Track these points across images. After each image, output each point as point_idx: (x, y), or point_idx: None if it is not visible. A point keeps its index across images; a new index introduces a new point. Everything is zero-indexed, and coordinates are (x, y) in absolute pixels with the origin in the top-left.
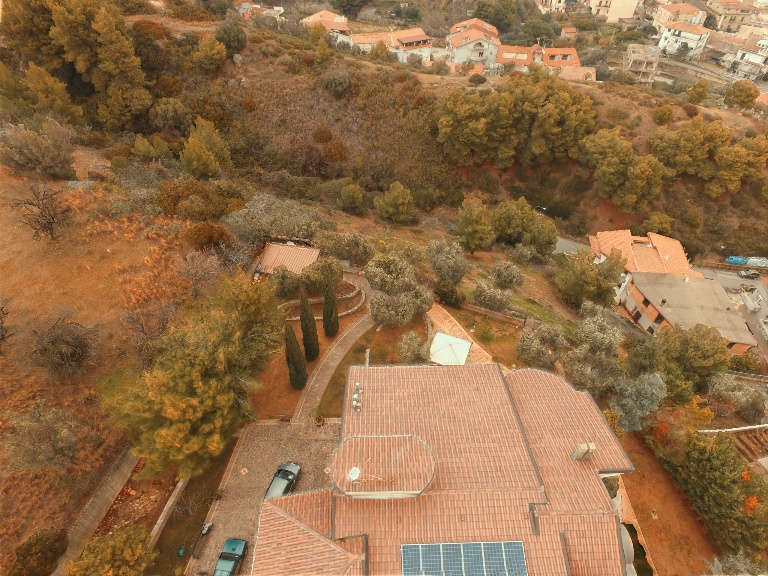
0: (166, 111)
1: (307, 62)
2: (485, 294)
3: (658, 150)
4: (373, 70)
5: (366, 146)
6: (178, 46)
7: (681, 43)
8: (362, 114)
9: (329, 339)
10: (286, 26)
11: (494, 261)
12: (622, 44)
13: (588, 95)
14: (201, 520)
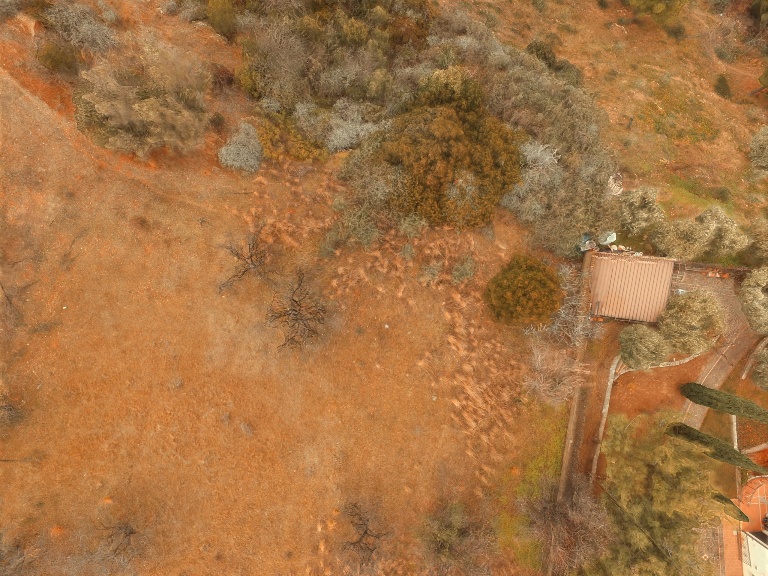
0: None
1: None
2: None
3: None
4: None
5: None
6: None
7: None
8: None
9: (682, 395)
10: None
11: None
12: None
13: None
14: None
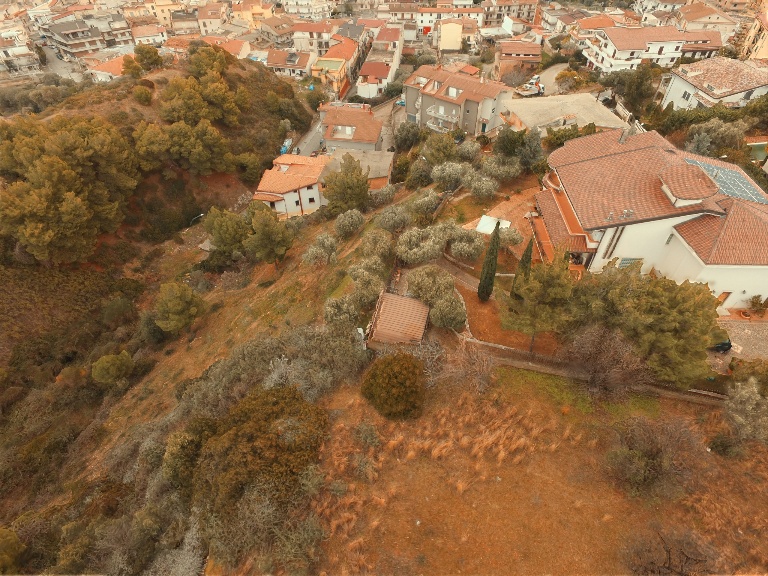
0: None
1: None
2: (430, 202)
3: None
4: None
5: None
6: None
7: None
8: None
9: (488, 301)
10: None
11: (292, 248)
12: None
13: None
14: None
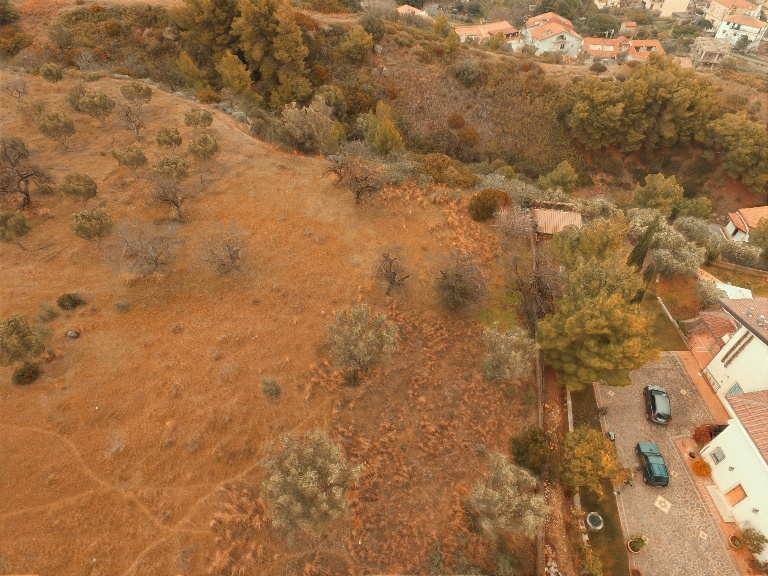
0: (329, 97)
1: (438, 52)
2: (739, 251)
3: None
4: (497, 60)
5: (497, 132)
6: (325, 37)
7: (741, 36)
8: (491, 101)
9: None
10: (402, 19)
11: None
12: (682, 37)
13: (708, 82)
14: (598, 431)
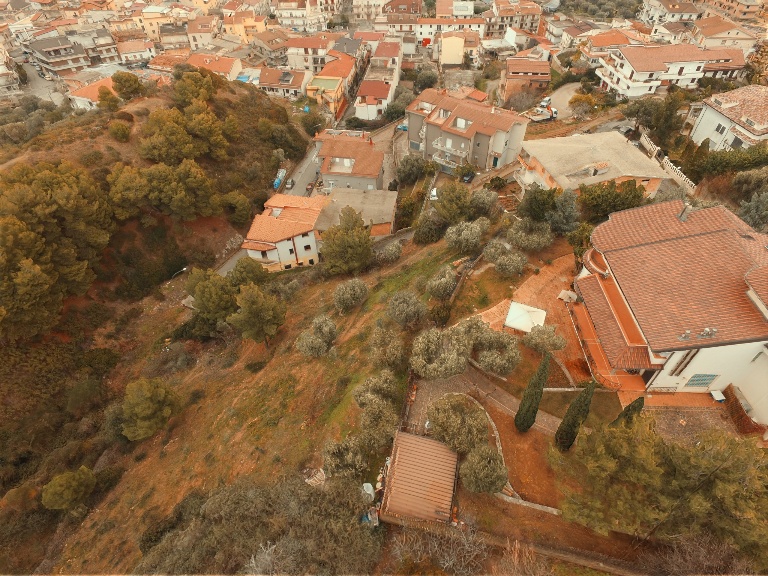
0: None
1: None
2: (448, 284)
3: (163, 157)
4: None
5: None
6: None
7: None
8: None
9: (528, 430)
10: None
11: (285, 318)
12: None
13: None
14: None
